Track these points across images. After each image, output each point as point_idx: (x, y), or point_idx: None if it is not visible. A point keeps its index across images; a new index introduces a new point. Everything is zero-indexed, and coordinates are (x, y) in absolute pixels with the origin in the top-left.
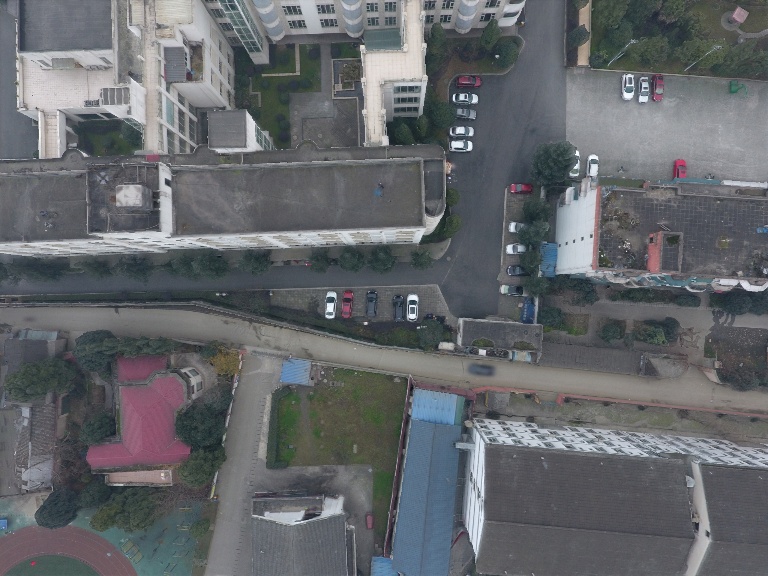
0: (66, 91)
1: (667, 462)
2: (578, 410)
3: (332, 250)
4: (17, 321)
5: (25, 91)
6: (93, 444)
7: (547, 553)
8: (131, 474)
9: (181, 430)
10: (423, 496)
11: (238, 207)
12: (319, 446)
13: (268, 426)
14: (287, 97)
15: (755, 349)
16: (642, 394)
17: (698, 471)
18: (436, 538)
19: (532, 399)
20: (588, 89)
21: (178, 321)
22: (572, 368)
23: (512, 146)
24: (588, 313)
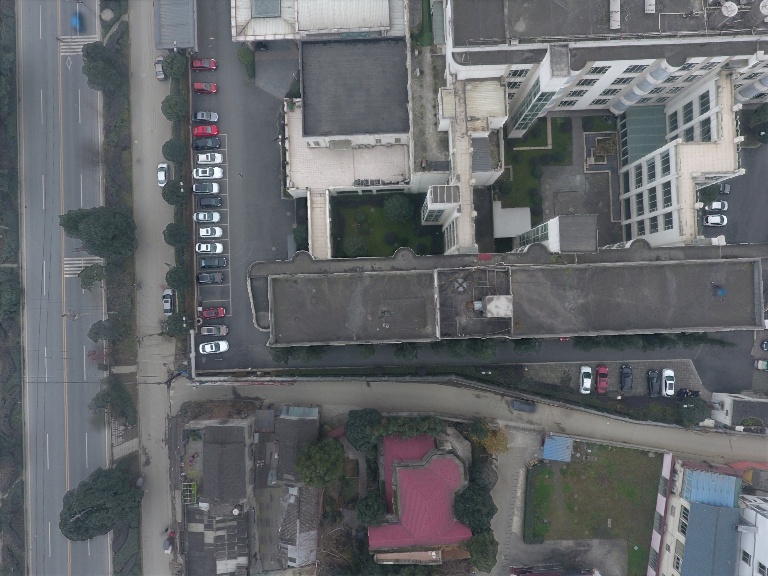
0: (332, 169)
1: None
2: None
3: None
4: (269, 394)
5: (291, 170)
6: None
7: None
8: None
9: (463, 512)
10: None
11: (569, 306)
12: (573, 520)
13: (522, 500)
14: None
15: None
16: None
17: None
18: None
19: None
20: None
21: (430, 395)
22: None
23: (764, 220)
24: None
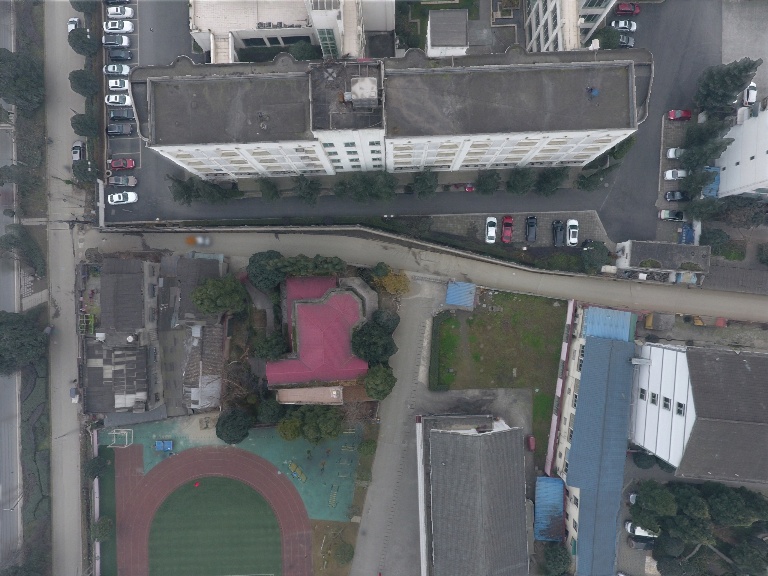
0: (236, 14)
1: None
2: (737, 334)
3: None
4: (178, 246)
5: (196, 14)
6: (271, 360)
7: (754, 452)
8: (300, 393)
9: (359, 346)
10: (600, 411)
11: (447, 111)
12: (479, 370)
13: (428, 350)
14: None
15: None
16: None
17: None
18: (613, 452)
19: (691, 323)
20: (744, 17)
21: (338, 246)
22: (734, 291)
23: (669, 74)
24: None
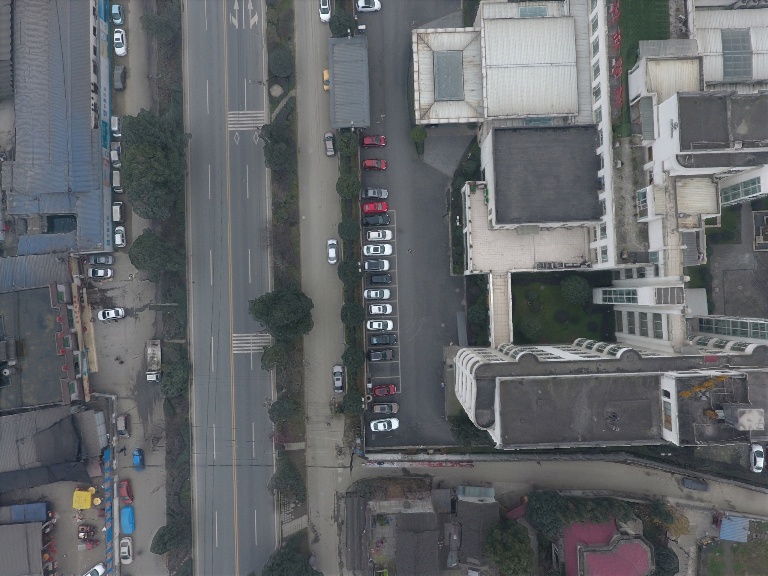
0: (513, 251)
1: None
2: None
3: None
4: (438, 471)
5: (472, 251)
6: None
7: None
8: None
9: None
10: None
11: None
12: None
13: None
14: None
15: None
16: None
17: None
18: None
19: None
20: None
21: (600, 472)
22: None
23: None
24: None
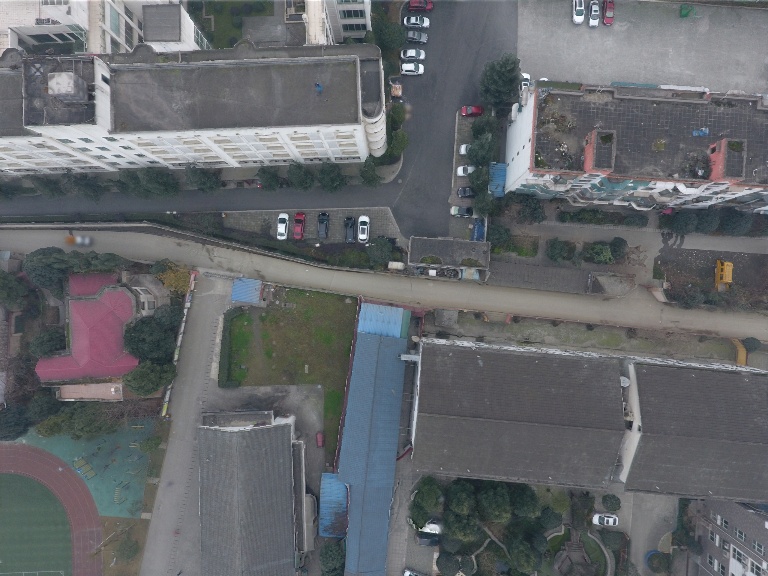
0: (18, 10)
1: (602, 361)
2: (527, 330)
3: (282, 169)
4: None
5: None
6: (43, 357)
7: (481, 448)
8: (82, 390)
9: (129, 342)
10: (368, 407)
11: (176, 106)
12: (271, 366)
13: (220, 347)
14: (239, 20)
15: (704, 271)
16: (591, 315)
17: (633, 370)
18: (381, 448)
19: (482, 319)
20: (539, 13)
21: (132, 243)
22: (521, 287)
23: (463, 70)
24: (538, 235)
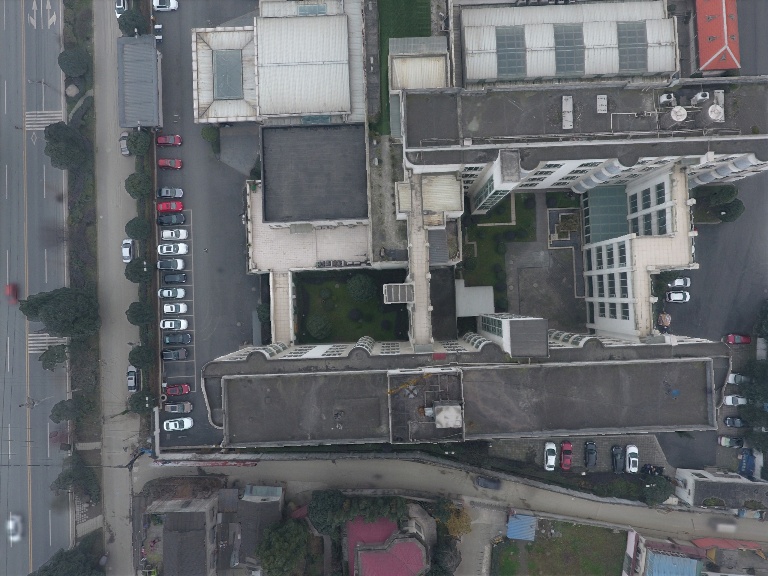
0: (295, 250)
1: None
2: None
3: None
4: (234, 471)
5: (254, 250)
6: None
7: None
8: None
9: None
10: None
11: (523, 404)
12: None
13: None
14: (505, 248)
15: None
16: None
17: None
18: None
19: (753, 551)
20: None
21: (395, 471)
22: None
23: (727, 295)
24: None
